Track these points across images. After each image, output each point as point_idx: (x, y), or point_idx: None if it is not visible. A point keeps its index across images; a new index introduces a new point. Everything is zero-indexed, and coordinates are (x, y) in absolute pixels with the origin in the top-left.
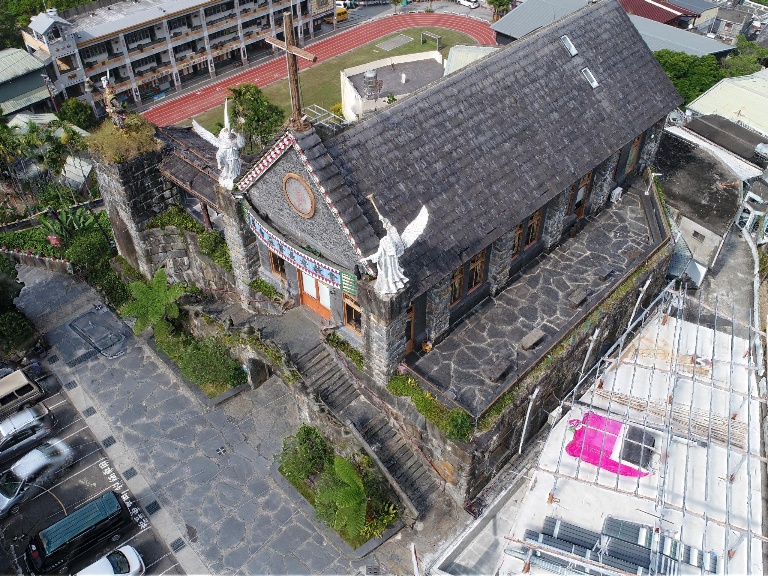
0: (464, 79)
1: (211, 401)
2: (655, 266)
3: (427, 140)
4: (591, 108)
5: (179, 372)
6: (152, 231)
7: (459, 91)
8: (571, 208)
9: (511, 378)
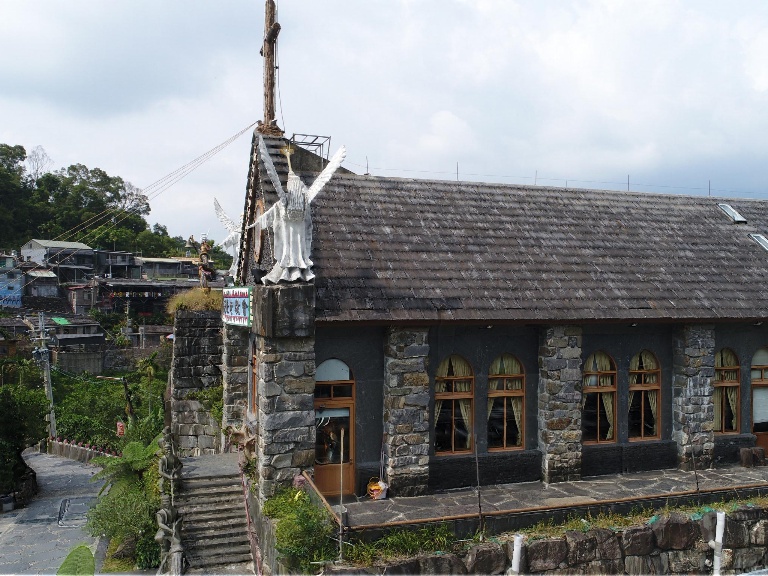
0: (542, 191)
1: (97, 574)
2: None
3: (454, 211)
4: (762, 267)
5: (103, 545)
6: (189, 402)
7: (528, 195)
8: (741, 417)
9: None
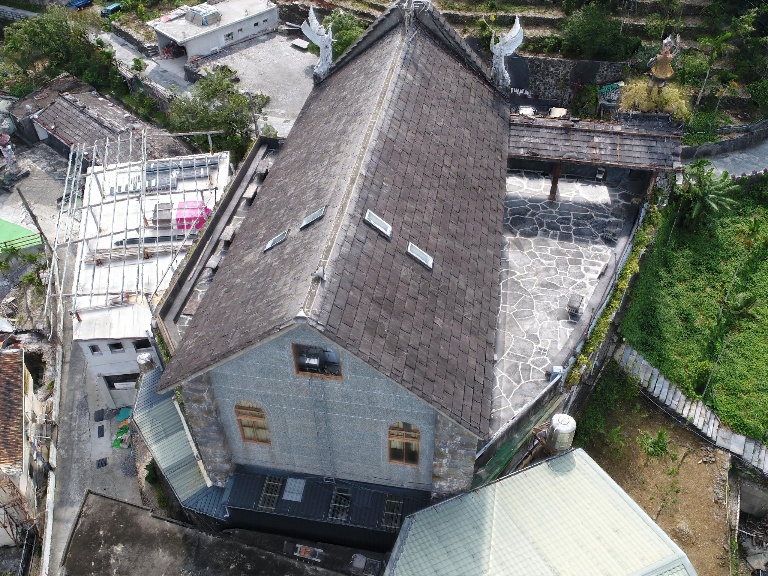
0: None
1: None
2: (169, 287)
3: None
4: None
5: None
6: None
7: None
8: None
9: (254, 170)
